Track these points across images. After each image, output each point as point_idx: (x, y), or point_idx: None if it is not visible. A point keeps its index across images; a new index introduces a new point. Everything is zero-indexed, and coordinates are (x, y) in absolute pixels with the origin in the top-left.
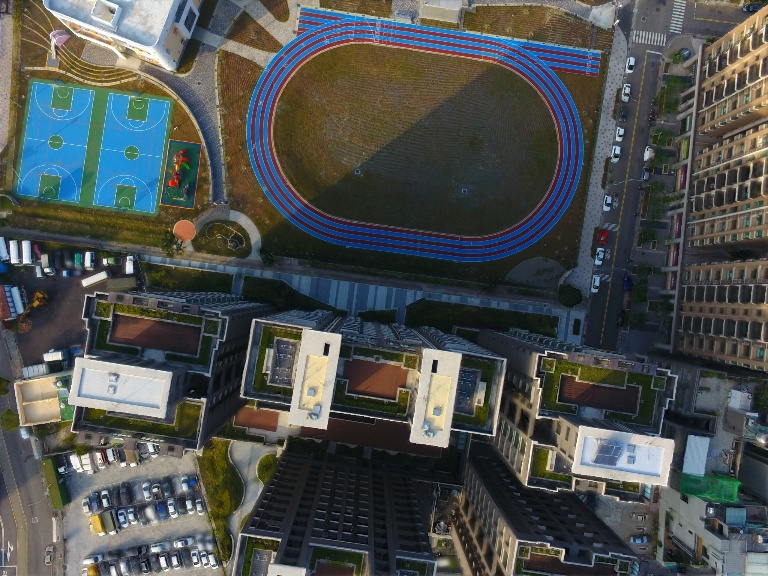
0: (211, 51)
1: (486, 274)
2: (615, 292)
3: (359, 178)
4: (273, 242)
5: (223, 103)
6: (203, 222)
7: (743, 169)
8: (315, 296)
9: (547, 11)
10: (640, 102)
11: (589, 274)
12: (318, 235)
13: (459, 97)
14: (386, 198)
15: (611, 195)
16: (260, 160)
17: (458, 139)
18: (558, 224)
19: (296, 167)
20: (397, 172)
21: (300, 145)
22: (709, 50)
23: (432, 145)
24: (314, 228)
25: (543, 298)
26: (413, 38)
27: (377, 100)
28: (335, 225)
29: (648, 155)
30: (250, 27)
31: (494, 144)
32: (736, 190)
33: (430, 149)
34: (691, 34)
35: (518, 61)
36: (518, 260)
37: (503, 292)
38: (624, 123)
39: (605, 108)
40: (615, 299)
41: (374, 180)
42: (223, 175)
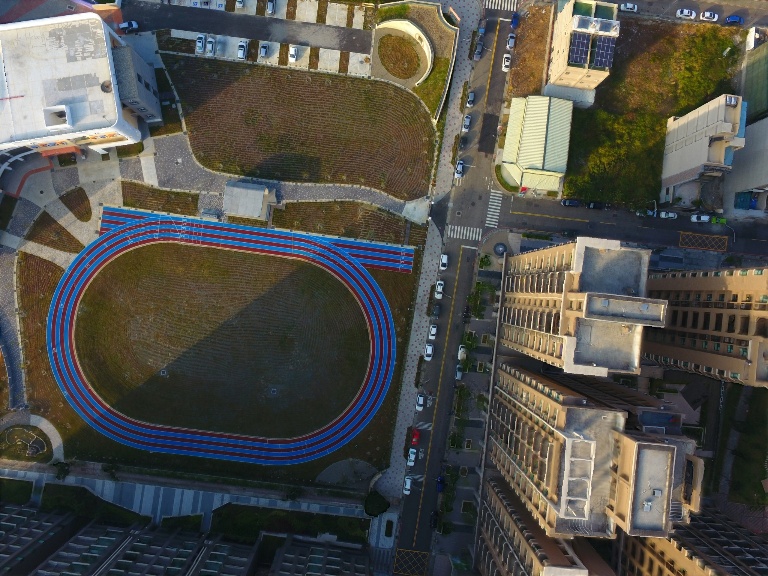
0: (10, 253)
1: (295, 476)
2: (429, 492)
3: (165, 379)
4: (75, 447)
5: (22, 306)
6: (3, 427)
7: (513, 417)
8: (119, 501)
9: (359, 207)
10: (455, 298)
11: (402, 475)
12: (121, 440)
13: (268, 295)
14: (193, 399)
15: (424, 394)
16: (61, 364)
17: (267, 338)
18: (369, 425)
19: (99, 370)
20: (204, 373)
21: (103, 347)
22: (511, 261)
23: (240, 345)
24: (117, 433)
25: (355, 499)
26: (220, 236)
27: (183, 299)
28: (138, 429)
29: (459, 356)
30: (50, 227)
31: (305, 343)
32: (508, 436)
33: (238, 349)
34: (507, 228)
35: (329, 258)
36: (328, 462)
37: (313, 494)
38: (438, 320)
39: (418, 305)
40: (428, 500)
41: (180, 381)
42: (23, 379)
